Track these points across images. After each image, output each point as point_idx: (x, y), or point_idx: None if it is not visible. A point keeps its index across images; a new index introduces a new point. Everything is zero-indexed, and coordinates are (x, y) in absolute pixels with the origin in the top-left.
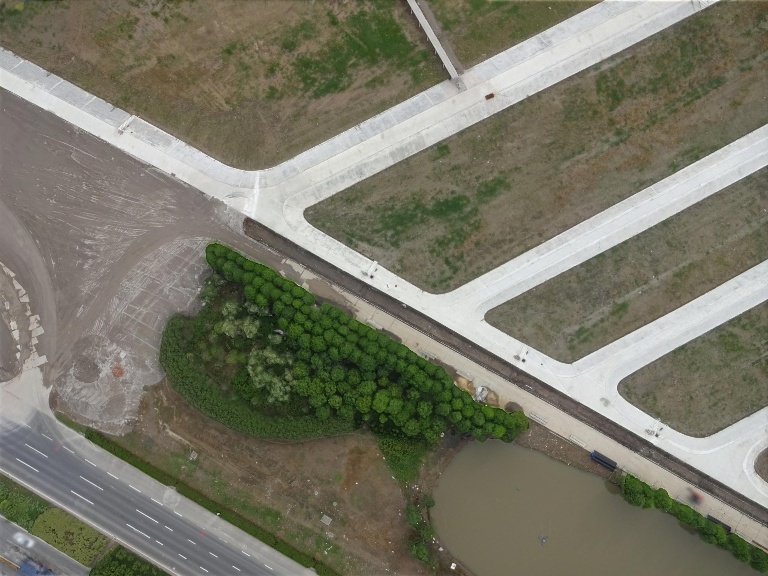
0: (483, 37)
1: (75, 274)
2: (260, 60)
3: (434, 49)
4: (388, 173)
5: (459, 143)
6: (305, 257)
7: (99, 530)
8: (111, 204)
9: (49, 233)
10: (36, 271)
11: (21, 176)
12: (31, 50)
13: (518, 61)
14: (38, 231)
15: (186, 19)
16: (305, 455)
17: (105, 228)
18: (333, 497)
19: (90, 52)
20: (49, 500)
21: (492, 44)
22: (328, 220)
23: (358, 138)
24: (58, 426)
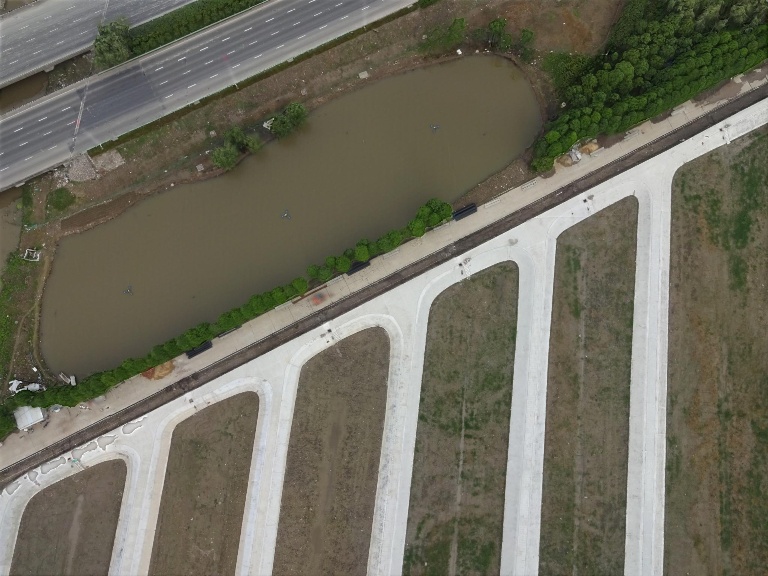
0: None
1: None
2: None
3: None
4: None
5: None
6: (763, 94)
7: None
8: None
9: None
10: None
11: None
12: None
13: None
14: None
15: None
16: (608, 2)
17: None
18: (565, 2)
19: None
20: None
21: None
22: None
23: None
24: None
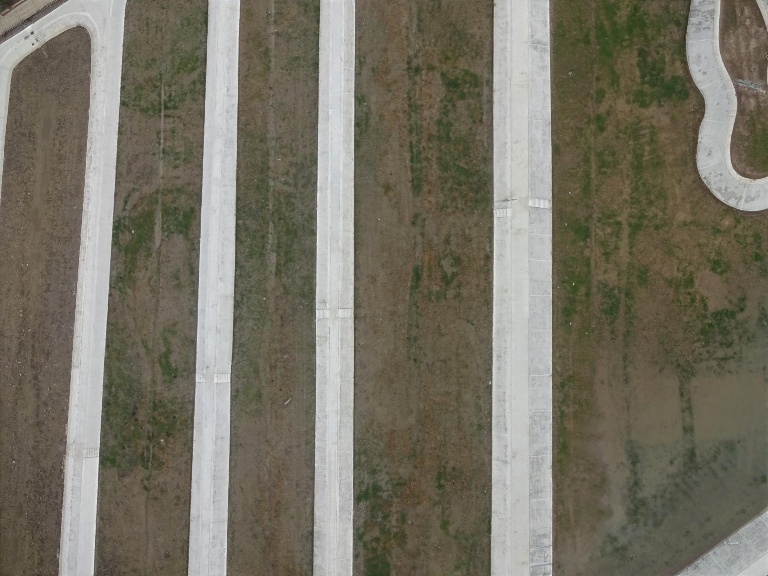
0: None
1: None
2: None
3: None
4: None
5: None
6: None
7: None
8: None
9: None
10: None
11: None
12: None
13: (532, 8)
14: None
15: None
16: None
17: None
18: None
19: None
20: None
21: (562, 2)
22: None
23: None
24: None
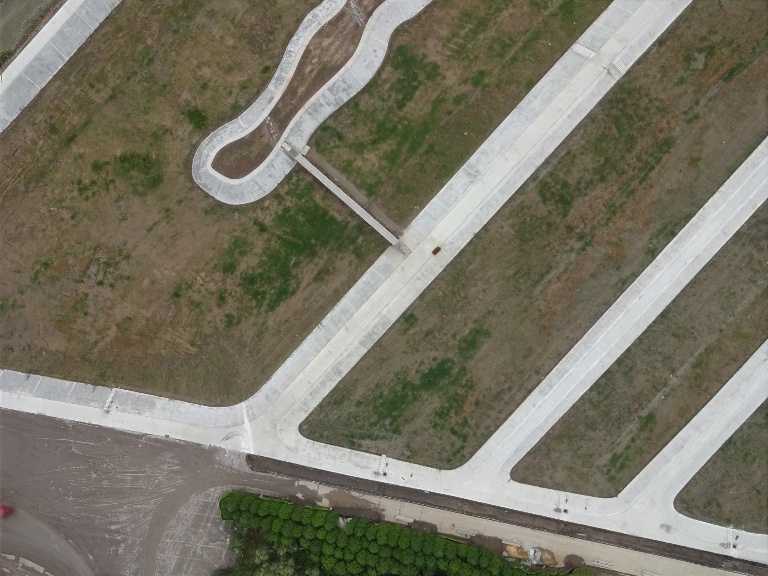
0: (410, 189)
1: (113, 562)
2: (208, 292)
3: (366, 222)
4: (365, 362)
5: (423, 307)
6: (315, 473)
7: None
8: (122, 484)
9: (78, 530)
10: (79, 570)
11: (36, 484)
12: (6, 358)
13: (452, 203)
14: (68, 531)
15: (128, 278)
16: None
17: (124, 508)
18: None
19: (56, 341)
20: None
21: (421, 193)
22: (324, 429)
23: (324, 338)
24: None
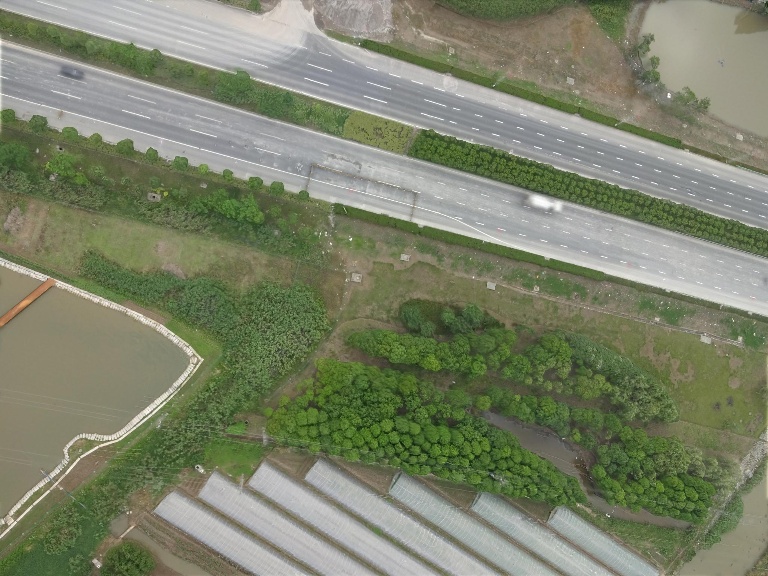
0: None
1: None
2: None
3: None
4: None
5: None
6: None
7: (400, 122)
8: None
9: None
10: None
11: None
12: None
13: None
14: None
15: None
16: (539, 33)
17: None
18: (570, 62)
19: None
20: (347, 107)
21: None
22: None
23: None
24: (332, 42)
